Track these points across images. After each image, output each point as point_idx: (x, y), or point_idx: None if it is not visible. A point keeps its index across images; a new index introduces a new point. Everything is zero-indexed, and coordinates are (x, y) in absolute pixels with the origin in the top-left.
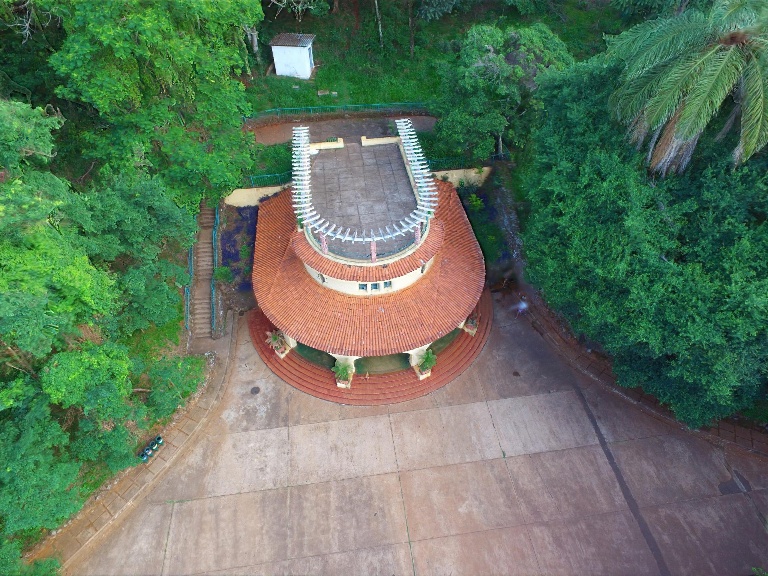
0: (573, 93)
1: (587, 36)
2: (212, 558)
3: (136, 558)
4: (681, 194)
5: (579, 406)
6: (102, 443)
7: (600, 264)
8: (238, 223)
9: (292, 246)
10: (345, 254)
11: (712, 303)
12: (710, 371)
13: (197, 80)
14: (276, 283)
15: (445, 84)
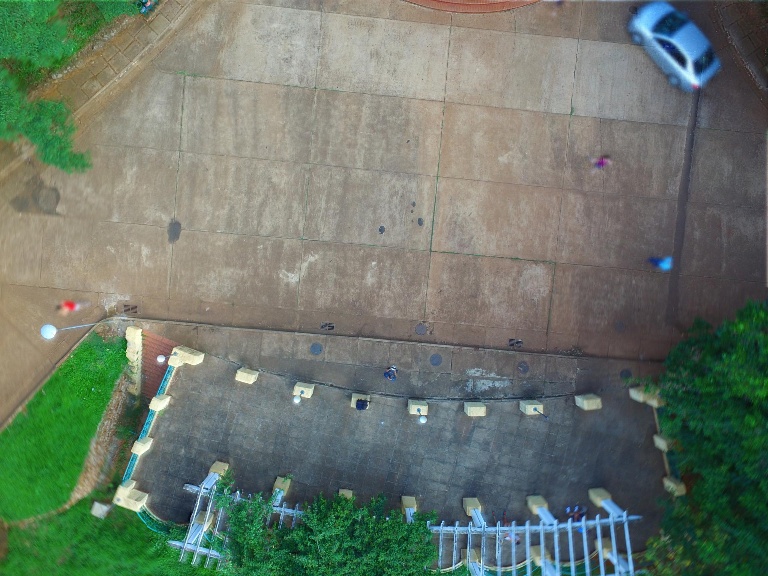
0: None
1: None
2: (231, 144)
3: (151, 125)
4: None
5: (690, 74)
6: None
7: None
8: None
9: None
10: None
11: None
12: None
13: None
14: None
15: None
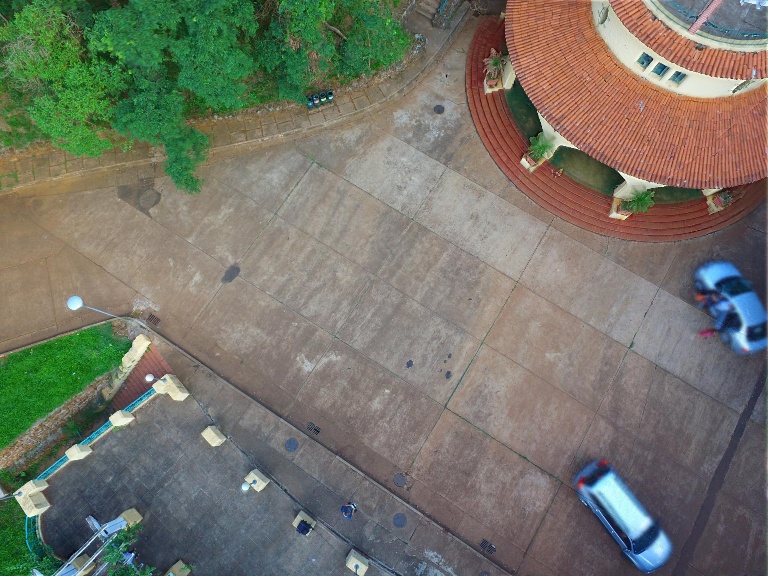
0: None
1: None
2: (320, 228)
3: (265, 184)
4: None
5: (757, 367)
6: (282, 58)
7: None
8: None
9: None
10: None
11: None
12: None
13: None
14: None
15: None
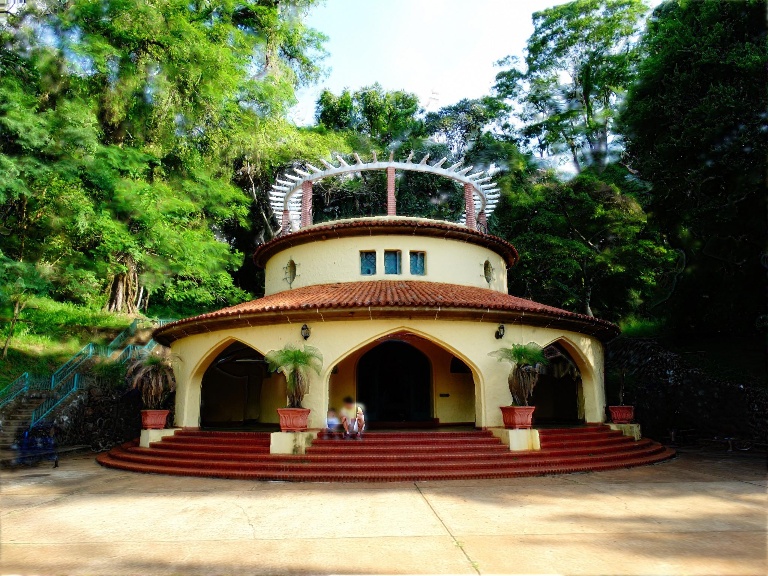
0: None
1: None
2: None
3: None
4: None
5: None
6: None
7: None
8: None
9: None
10: None
11: None
12: None
13: None
14: None
15: None
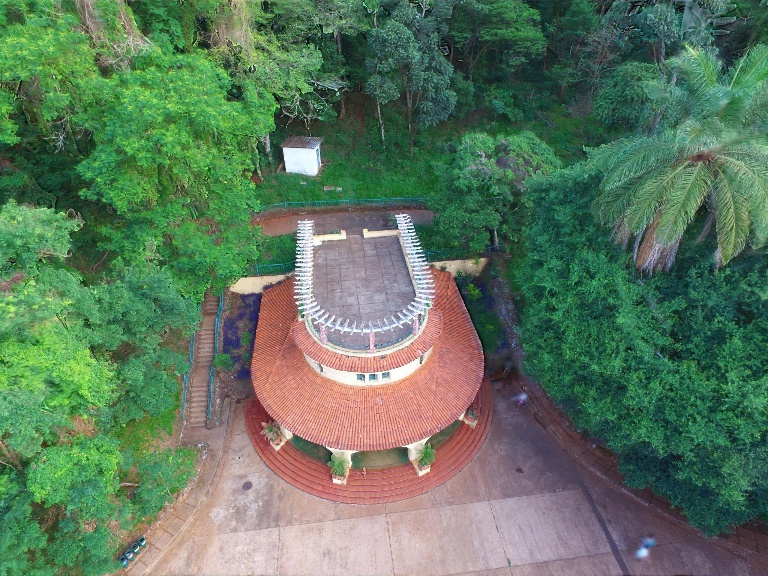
0: (559, 197)
1: (573, 140)
2: None
3: None
4: (669, 292)
5: (587, 507)
6: (81, 546)
7: (596, 360)
8: (241, 310)
9: (292, 335)
10: (344, 344)
11: (711, 402)
12: (719, 473)
13: (211, 181)
14: (275, 372)
15: (442, 183)
